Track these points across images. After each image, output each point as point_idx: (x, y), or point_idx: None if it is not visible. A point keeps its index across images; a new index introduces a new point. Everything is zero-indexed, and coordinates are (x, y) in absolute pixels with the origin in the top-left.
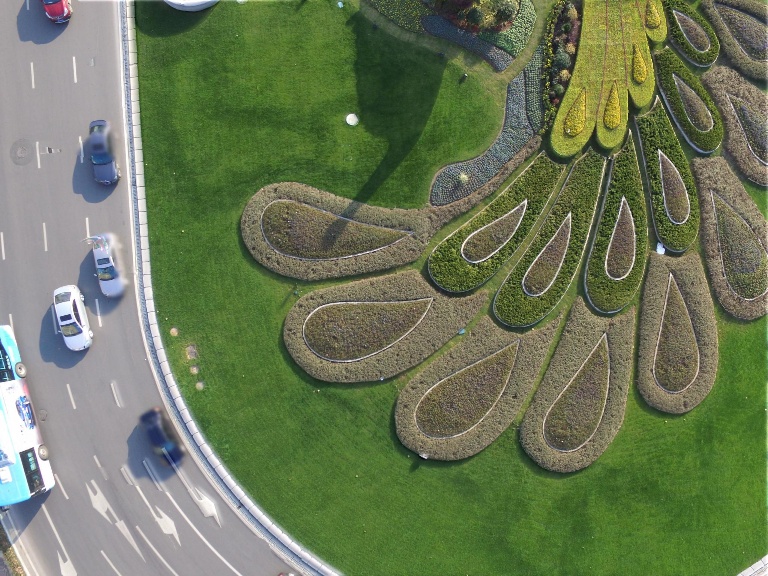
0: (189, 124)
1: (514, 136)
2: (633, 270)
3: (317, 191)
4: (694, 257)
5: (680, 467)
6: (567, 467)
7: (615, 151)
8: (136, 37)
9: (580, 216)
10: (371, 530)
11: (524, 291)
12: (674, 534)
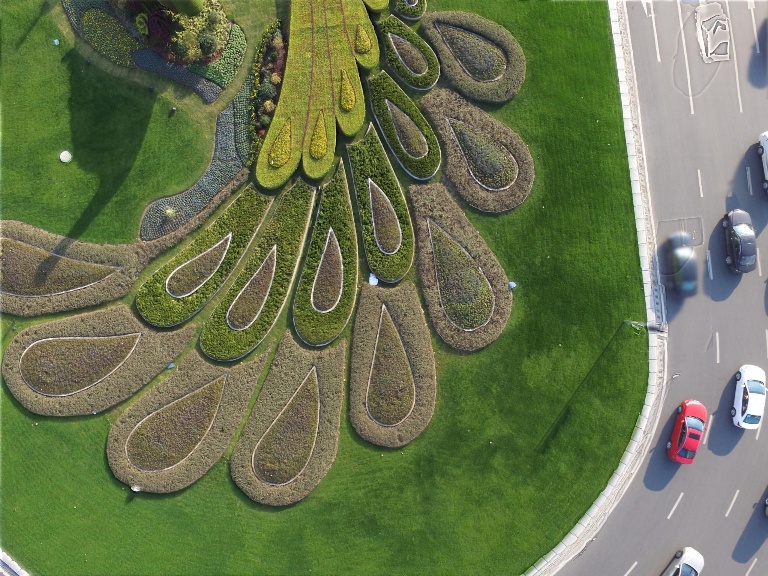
0: None
1: (222, 169)
2: (340, 302)
3: (32, 229)
4: (408, 288)
5: (398, 501)
6: (277, 501)
7: (326, 181)
8: None
9: (285, 249)
10: (92, 559)
11: (228, 325)
12: (395, 568)
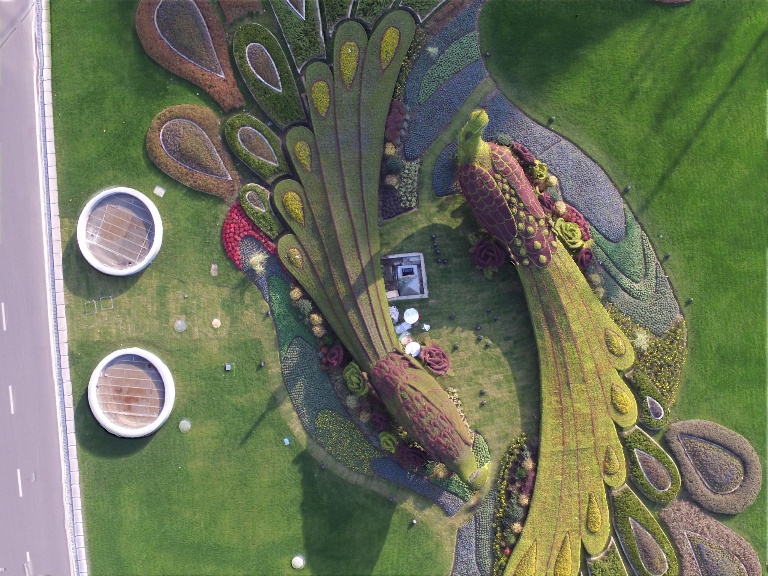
0: (133, 554)
1: None
2: None
3: None
4: None
5: None
6: None
7: None
8: (77, 455)
9: None
10: None
11: None
12: None
